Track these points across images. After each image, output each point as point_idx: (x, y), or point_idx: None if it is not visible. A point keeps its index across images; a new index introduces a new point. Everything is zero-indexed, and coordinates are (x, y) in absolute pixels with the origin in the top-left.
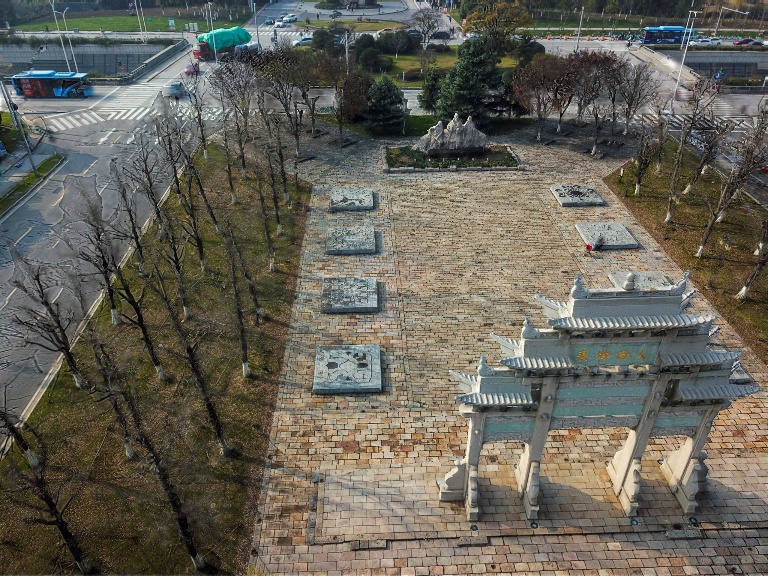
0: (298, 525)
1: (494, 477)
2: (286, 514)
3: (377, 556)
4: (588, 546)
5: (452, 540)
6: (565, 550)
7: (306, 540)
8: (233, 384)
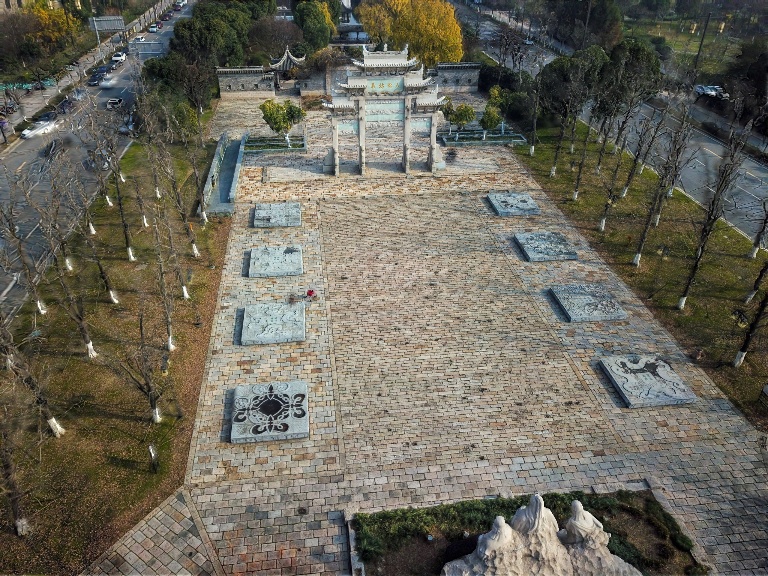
0: None
1: None
2: None
3: None
4: None
5: None
6: None
7: None
8: None
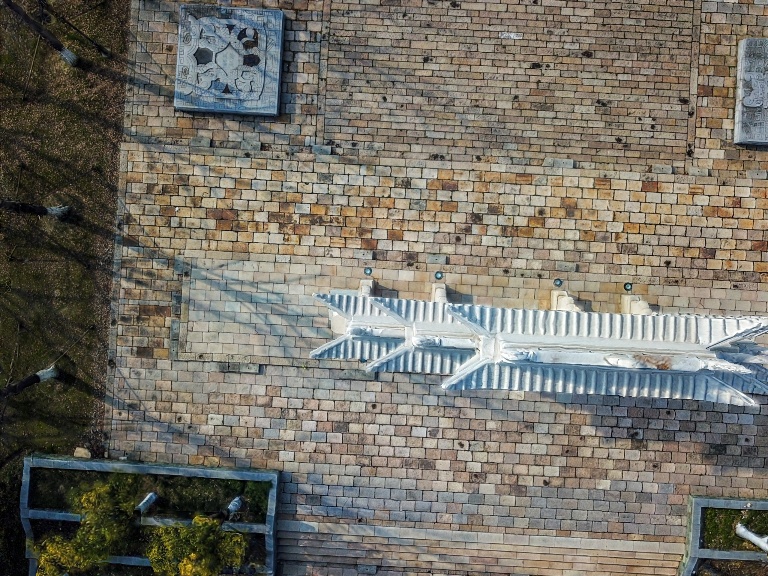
0: (159, 333)
1: (405, 290)
2: (145, 317)
3: (248, 381)
4: (487, 393)
5: (335, 370)
6: (459, 395)
7: (168, 356)
8: (55, 77)
